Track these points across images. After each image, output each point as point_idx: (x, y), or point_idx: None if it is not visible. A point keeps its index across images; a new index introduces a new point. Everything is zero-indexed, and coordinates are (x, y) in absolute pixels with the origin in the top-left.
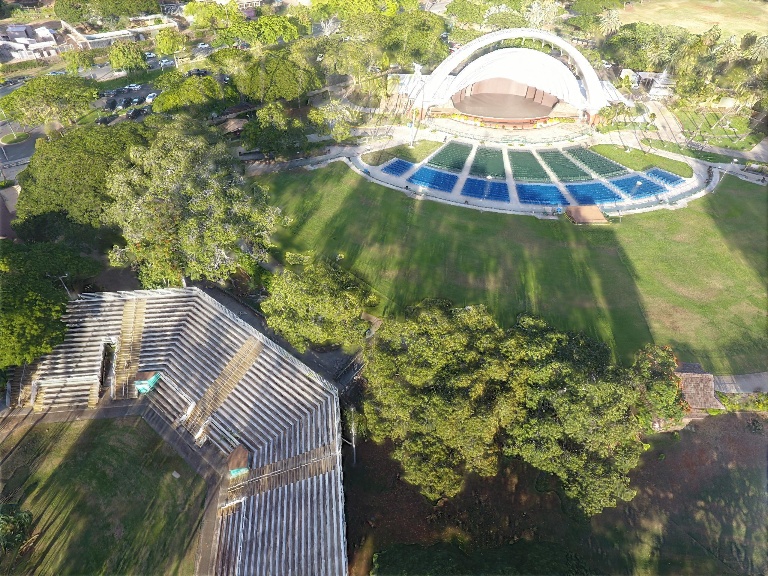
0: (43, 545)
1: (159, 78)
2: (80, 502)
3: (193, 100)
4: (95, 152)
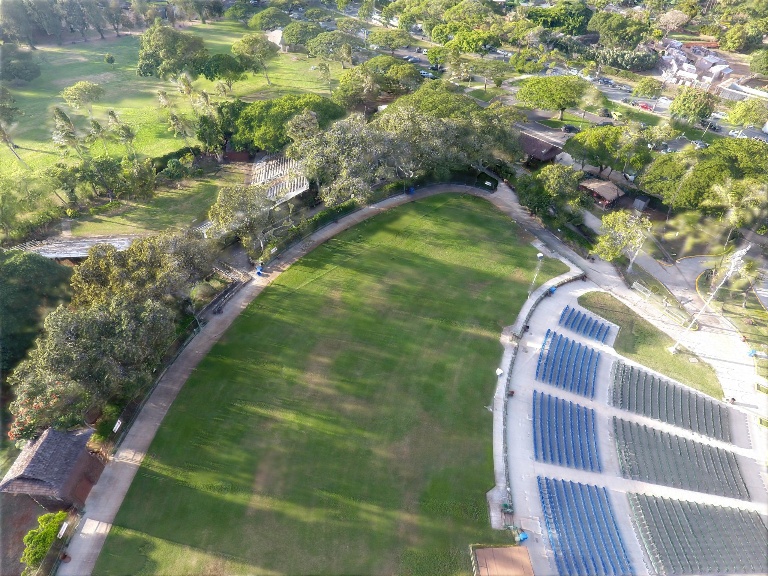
0: (176, 191)
1: (651, 126)
2: (193, 195)
3: (588, 140)
4: (421, 103)
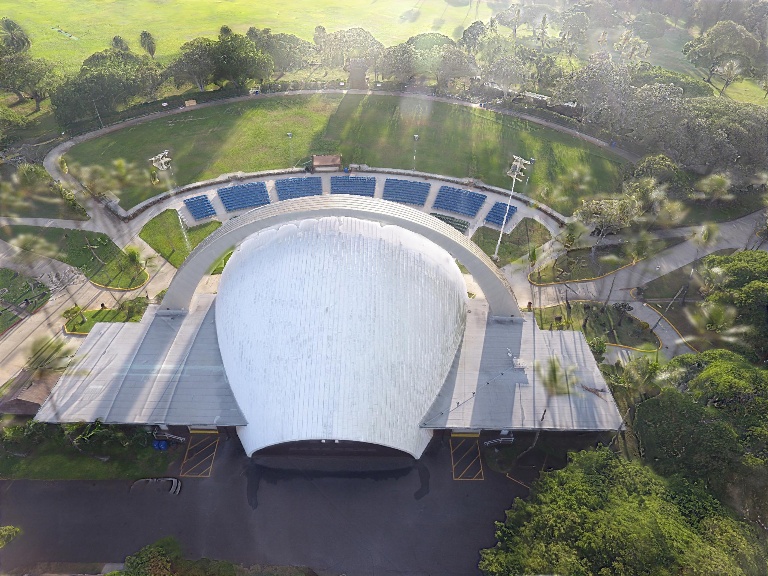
0: None
1: None
2: None
3: None
4: None
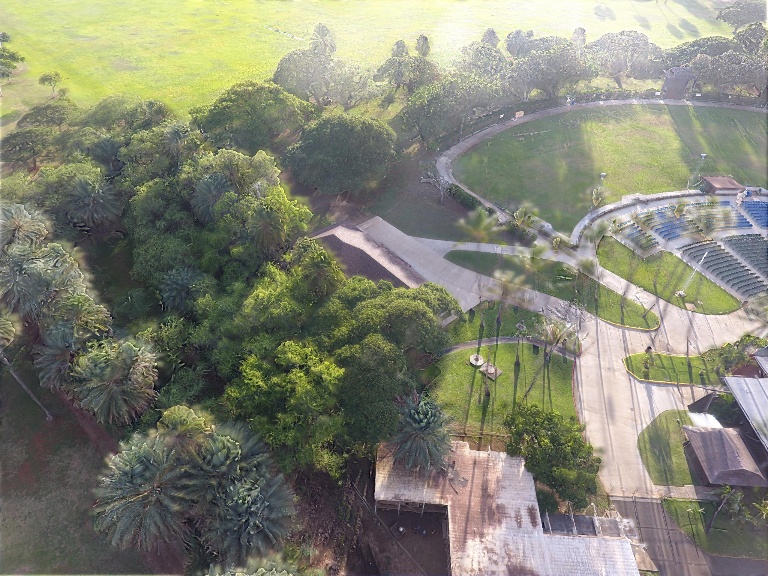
0: None
1: None
2: None
3: None
4: None
